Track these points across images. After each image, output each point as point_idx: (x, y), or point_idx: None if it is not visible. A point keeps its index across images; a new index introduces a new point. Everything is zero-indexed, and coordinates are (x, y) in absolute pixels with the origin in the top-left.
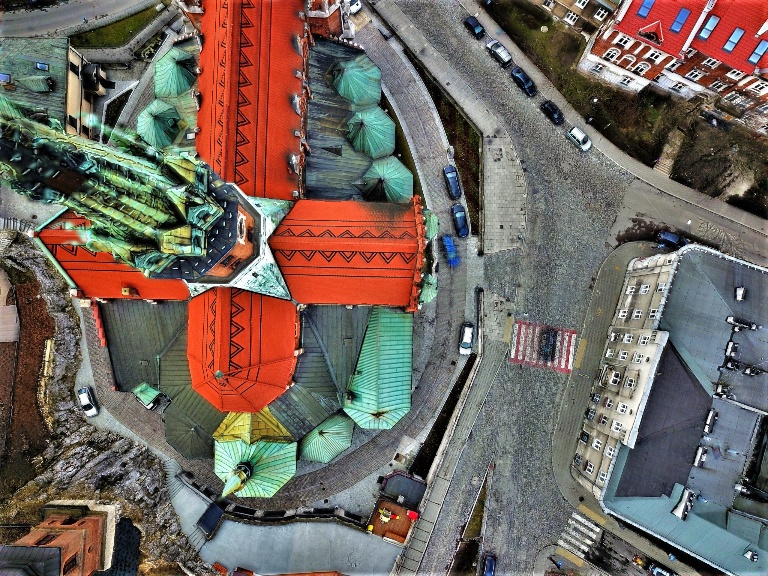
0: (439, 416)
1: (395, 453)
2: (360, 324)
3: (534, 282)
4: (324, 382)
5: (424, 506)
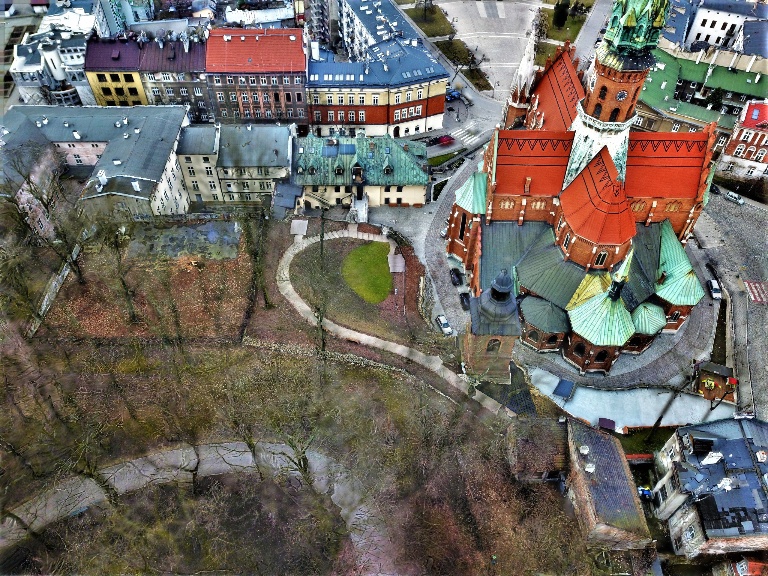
0: (716, 336)
1: (692, 359)
2: (655, 236)
3: (745, 262)
4: (640, 271)
5: (738, 378)
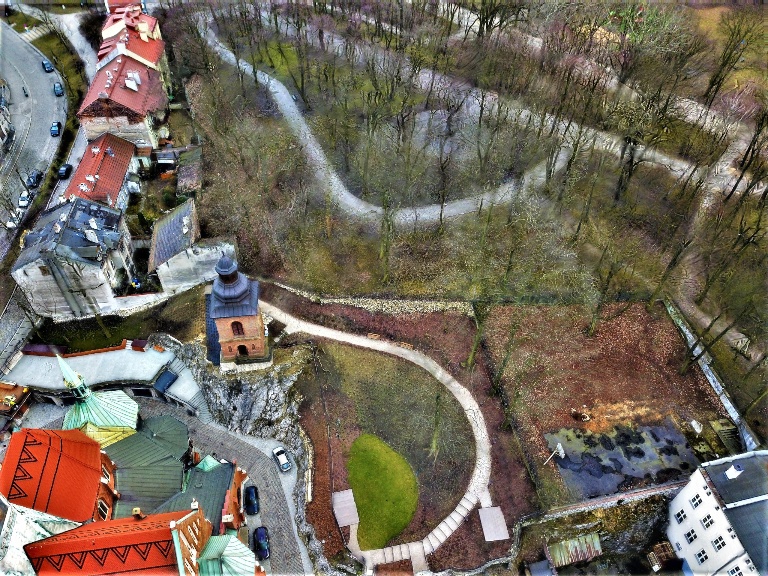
0: None
1: None
2: None
3: None
4: None
5: None
